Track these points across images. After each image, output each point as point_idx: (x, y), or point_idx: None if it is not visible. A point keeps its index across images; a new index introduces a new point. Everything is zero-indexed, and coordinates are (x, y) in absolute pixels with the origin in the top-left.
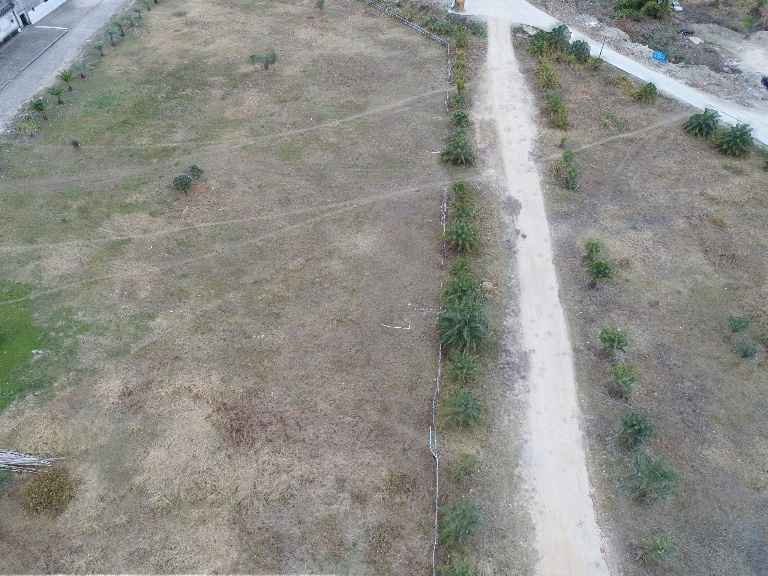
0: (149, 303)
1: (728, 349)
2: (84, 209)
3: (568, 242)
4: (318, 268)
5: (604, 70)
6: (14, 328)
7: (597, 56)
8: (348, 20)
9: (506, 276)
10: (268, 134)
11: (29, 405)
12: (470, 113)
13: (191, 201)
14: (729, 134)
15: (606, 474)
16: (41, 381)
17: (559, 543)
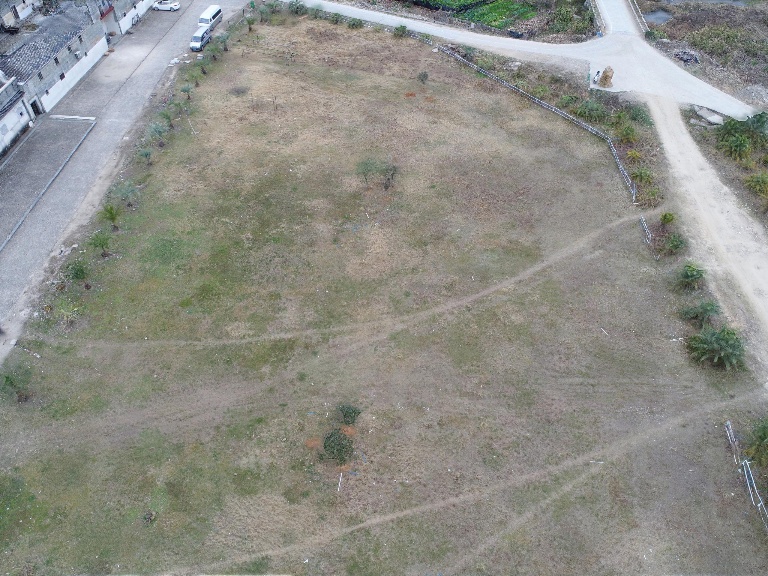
0: None
1: None
2: (177, 488)
3: None
4: None
5: None
6: None
7: None
8: (460, 98)
9: None
10: (420, 309)
11: None
12: (691, 261)
13: (345, 463)
14: None
15: None
16: None
17: None
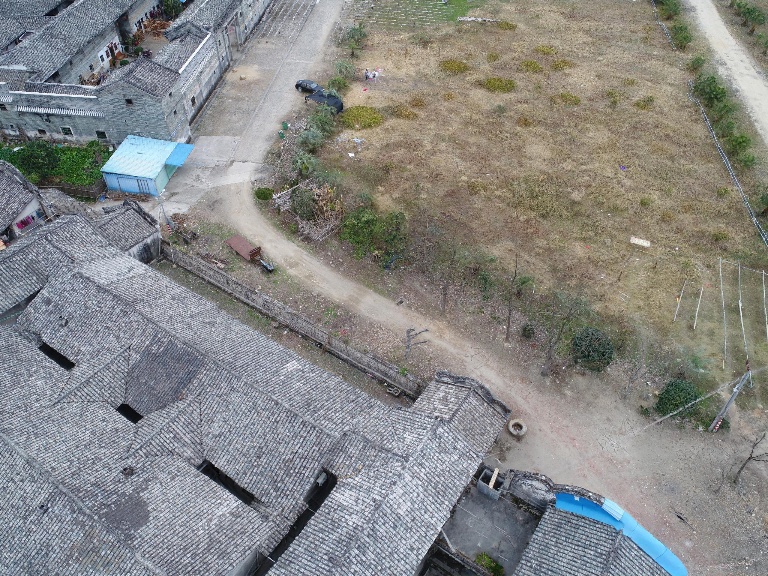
0: None
1: None
2: None
3: None
4: None
5: None
6: None
7: None
8: None
9: None
10: None
11: (478, 10)
12: None
13: None
14: None
15: (736, 30)
16: (478, 6)
17: None
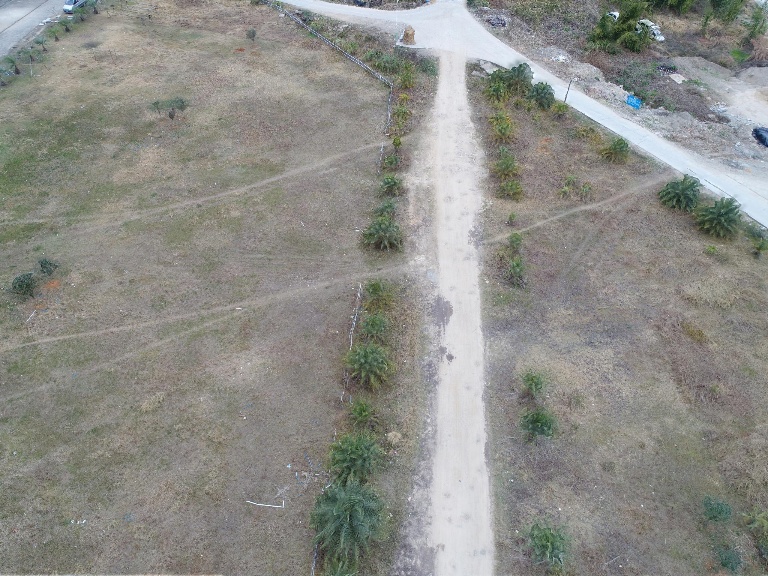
0: None
1: (703, 542)
2: None
3: (505, 366)
4: (180, 408)
5: (570, 118)
6: None
7: (563, 100)
8: (283, 53)
9: (420, 421)
10: (158, 205)
11: None
12: (406, 176)
13: (40, 304)
14: (712, 210)
15: None
16: None
17: None
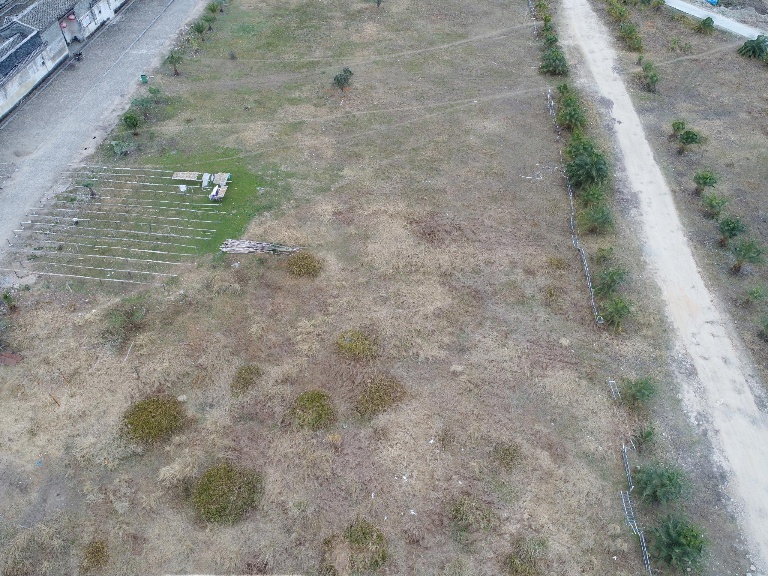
0: (335, 161)
1: None
2: (260, 101)
3: (655, 126)
4: (460, 141)
5: (665, 11)
6: (236, 174)
7: None
8: None
9: (610, 147)
10: (392, 53)
11: (268, 218)
12: None
13: (344, 97)
14: None
15: (708, 261)
16: (271, 205)
17: (680, 297)
